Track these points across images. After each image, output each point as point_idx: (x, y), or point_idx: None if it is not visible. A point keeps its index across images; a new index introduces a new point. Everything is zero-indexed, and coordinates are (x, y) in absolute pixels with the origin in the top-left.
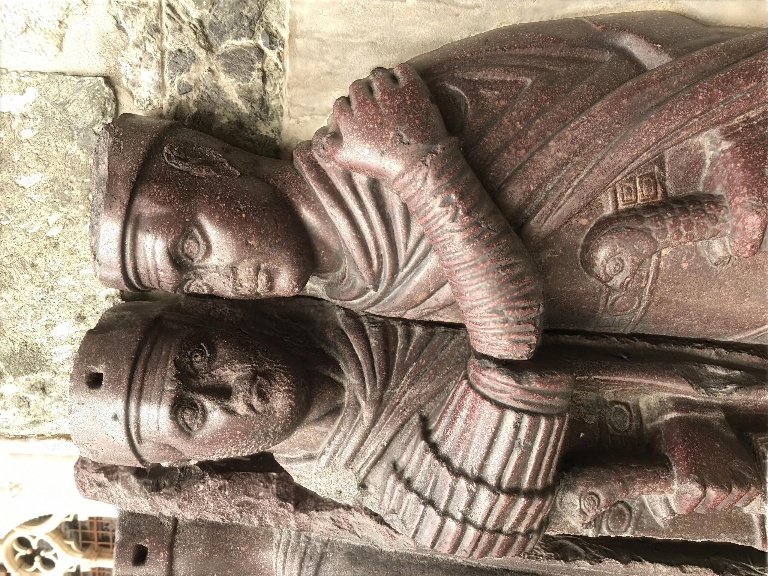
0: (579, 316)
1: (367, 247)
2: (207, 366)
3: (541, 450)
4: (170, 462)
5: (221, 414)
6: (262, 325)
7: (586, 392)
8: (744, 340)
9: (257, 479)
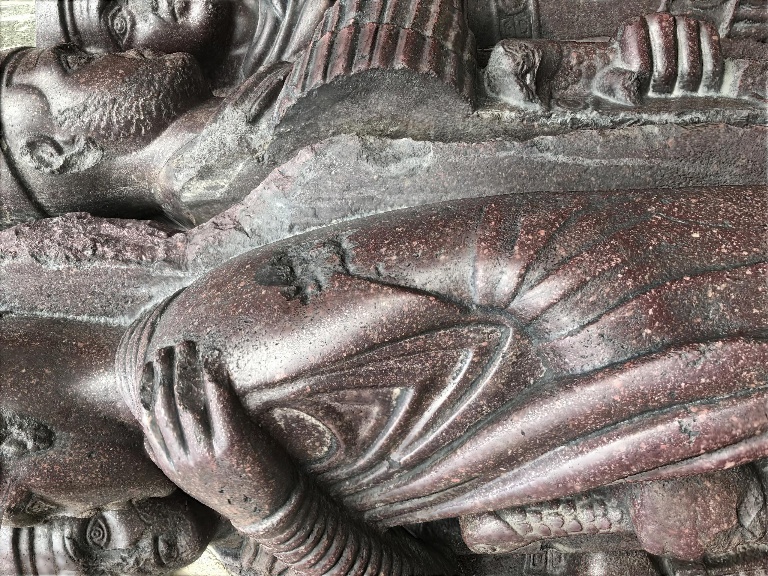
0: (480, 27)
1: None
2: None
3: None
4: (31, 136)
5: (108, 56)
6: None
7: None
8: None
9: None
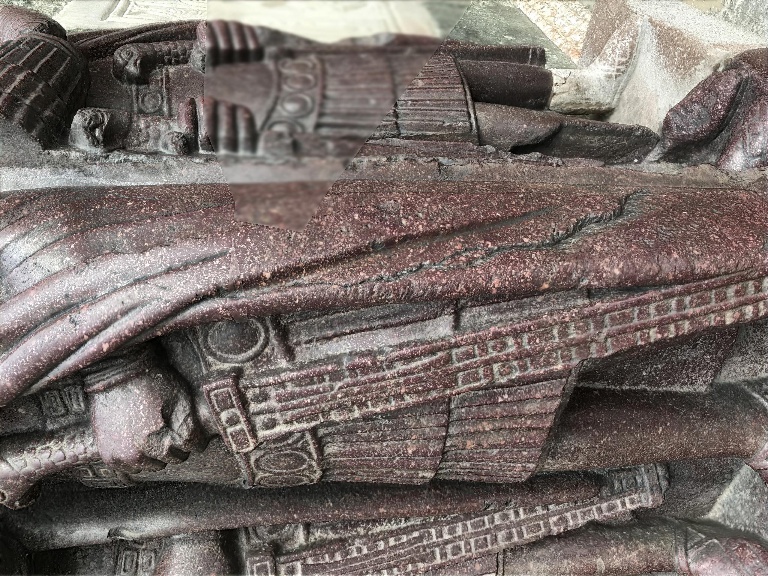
0: None
1: None
2: None
3: (38, 53)
4: None
5: None
6: None
7: None
8: None
9: None
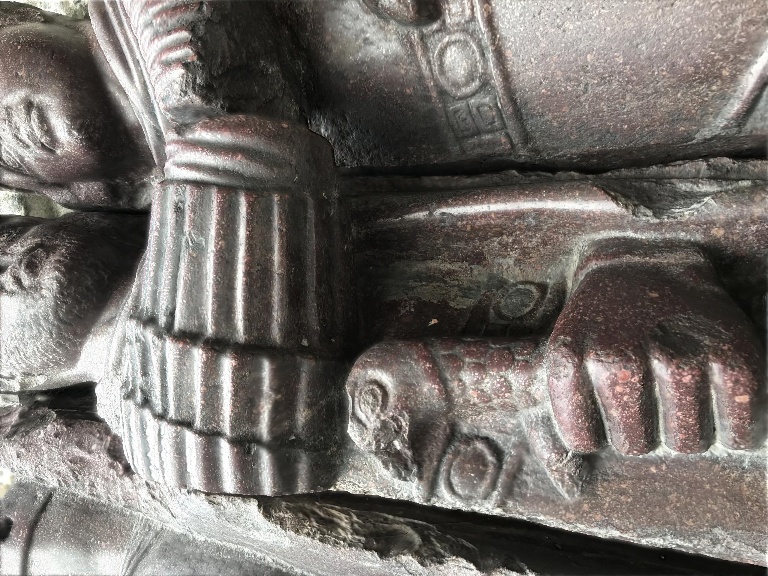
0: (418, 119)
1: (123, 54)
2: (6, 245)
3: (223, 255)
4: None
5: None
6: (132, 240)
7: (469, 266)
8: (761, 124)
9: (96, 429)
